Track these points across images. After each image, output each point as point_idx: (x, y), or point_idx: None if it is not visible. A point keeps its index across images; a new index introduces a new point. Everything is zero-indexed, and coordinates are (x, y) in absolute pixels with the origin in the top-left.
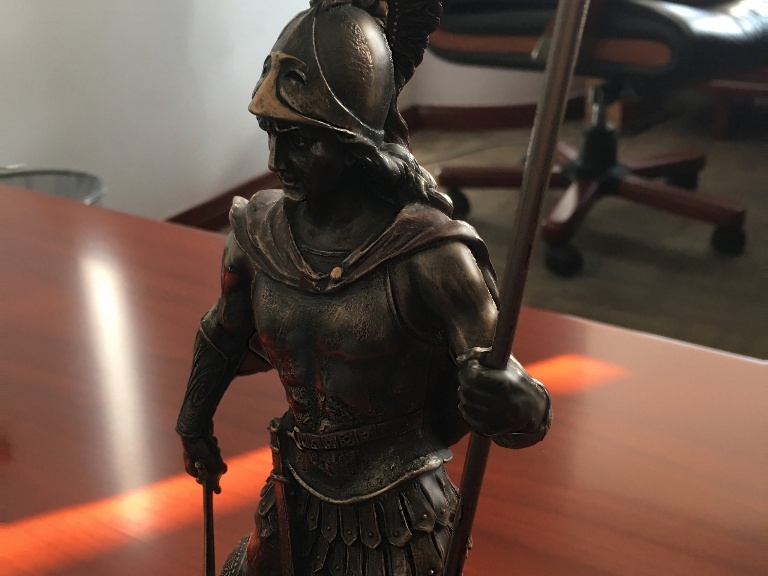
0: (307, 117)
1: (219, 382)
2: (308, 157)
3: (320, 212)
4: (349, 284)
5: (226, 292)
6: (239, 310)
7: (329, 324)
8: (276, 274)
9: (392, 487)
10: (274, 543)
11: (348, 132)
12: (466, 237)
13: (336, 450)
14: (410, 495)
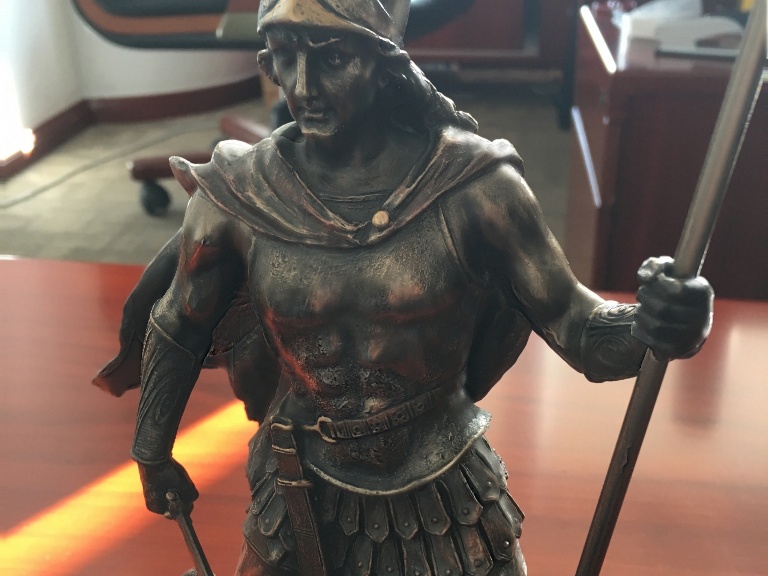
0: (355, 23)
1: (185, 388)
2: (344, 78)
3: (338, 150)
4: (398, 229)
5: (192, 273)
6: (212, 293)
7: (376, 282)
8: (289, 234)
9: (458, 459)
10: (287, 564)
11: (390, 42)
12: (514, 157)
13: (386, 432)
14: (470, 464)
